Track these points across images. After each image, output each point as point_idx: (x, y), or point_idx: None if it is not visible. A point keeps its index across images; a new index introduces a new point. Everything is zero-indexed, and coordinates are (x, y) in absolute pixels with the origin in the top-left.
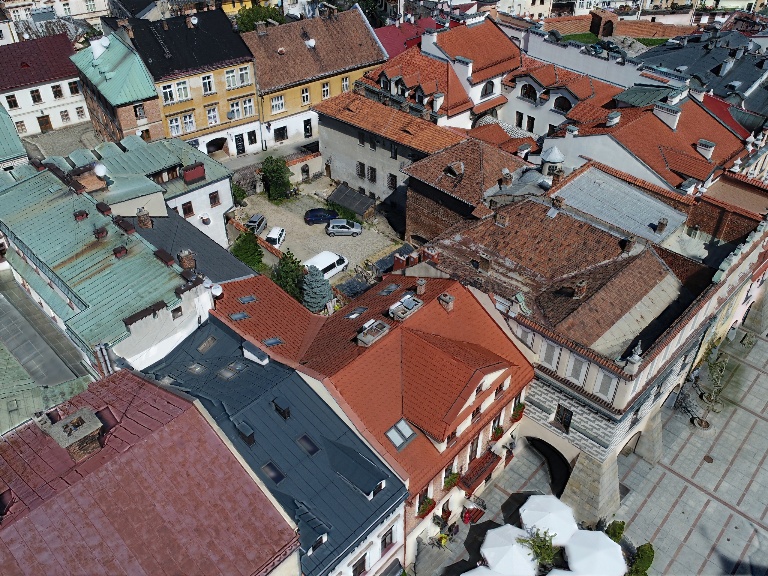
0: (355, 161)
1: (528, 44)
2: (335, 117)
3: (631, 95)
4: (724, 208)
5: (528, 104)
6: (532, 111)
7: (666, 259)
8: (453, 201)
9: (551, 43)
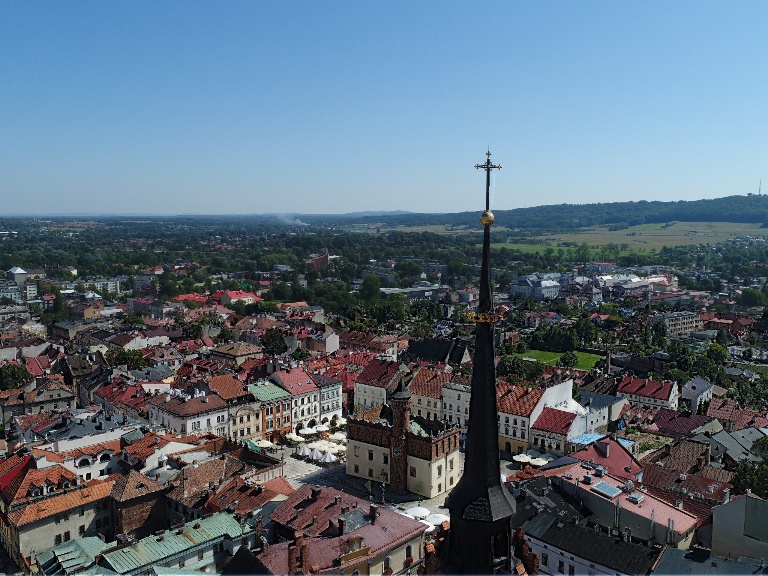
0: (53, 537)
1: (58, 447)
2: (40, 518)
3: (133, 437)
4: (215, 441)
5: (85, 468)
6: (89, 470)
7: (232, 455)
8: (150, 496)
9: (73, 440)
